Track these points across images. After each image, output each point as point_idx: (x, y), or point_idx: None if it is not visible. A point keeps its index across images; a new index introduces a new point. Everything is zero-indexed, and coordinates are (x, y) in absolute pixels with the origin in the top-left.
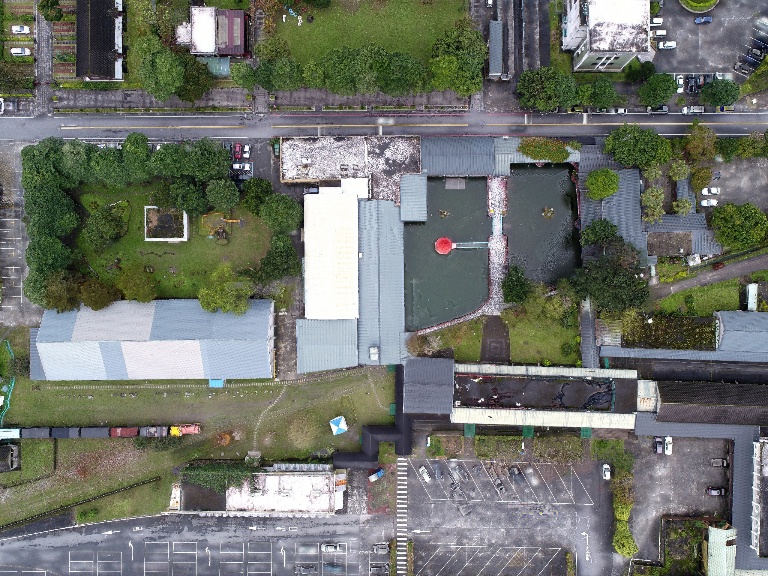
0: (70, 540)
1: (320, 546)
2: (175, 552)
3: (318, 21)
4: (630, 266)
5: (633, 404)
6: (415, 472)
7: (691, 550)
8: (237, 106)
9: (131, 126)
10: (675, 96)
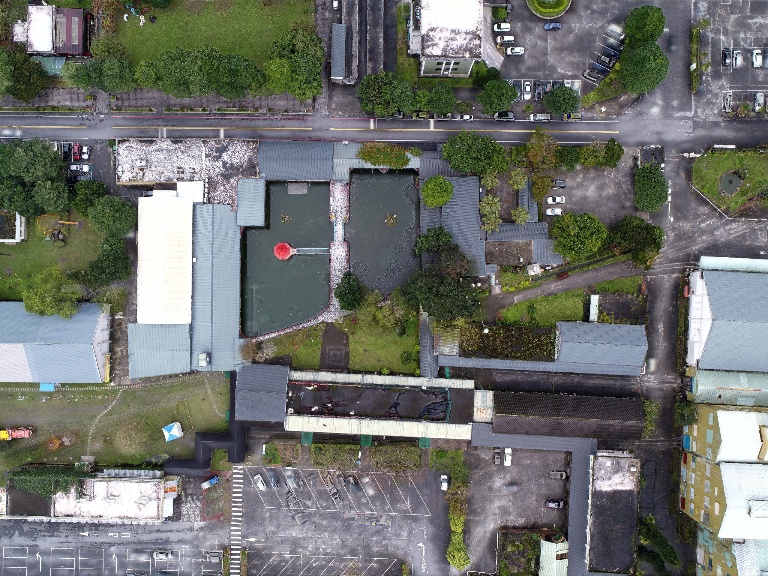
0: None
1: (153, 553)
2: (5, 557)
3: (161, 21)
4: (468, 275)
5: (469, 415)
6: (251, 480)
7: (528, 563)
8: (78, 106)
9: None
10: (523, 103)
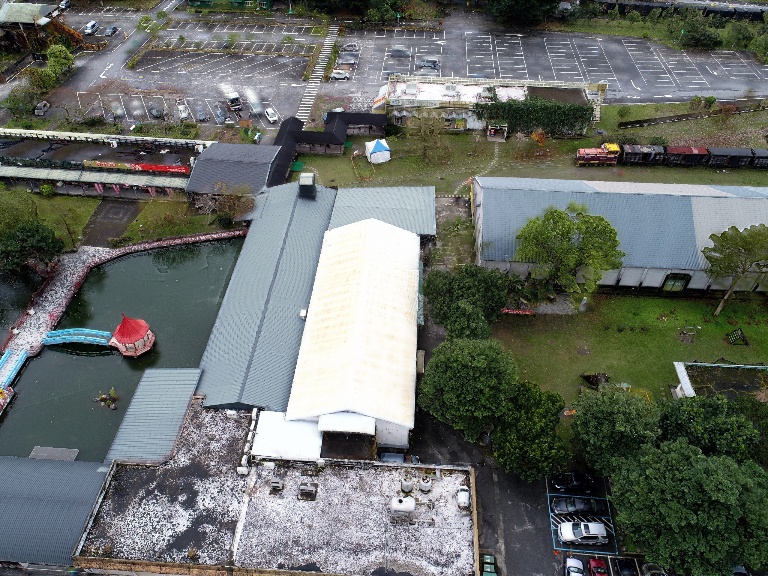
0: (714, 93)
1: None
2: None
3: None
4: None
5: None
6: None
7: None
8: None
9: None
10: None
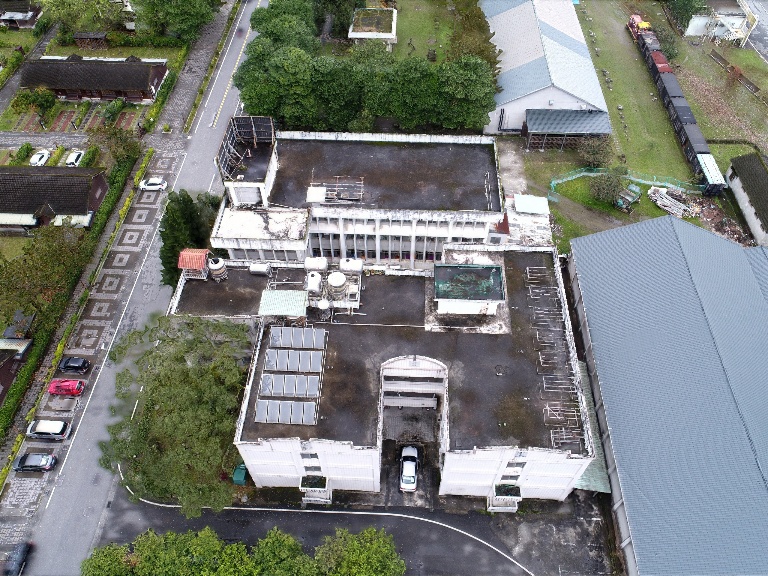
0: None
1: None
2: None
3: None
4: None
5: None
6: None
7: None
8: None
9: (233, 68)
10: None
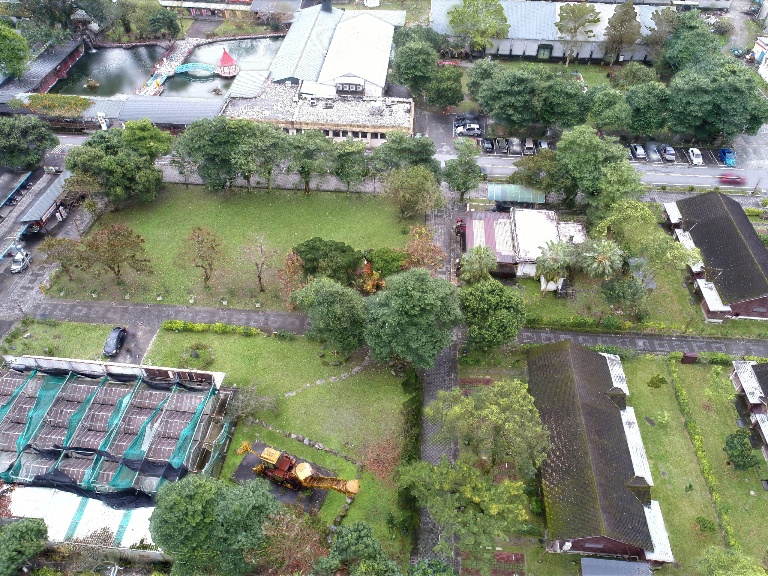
0: None
1: None
2: None
3: None
4: None
5: None
6: None
7: None
8: None
9: None
10: None
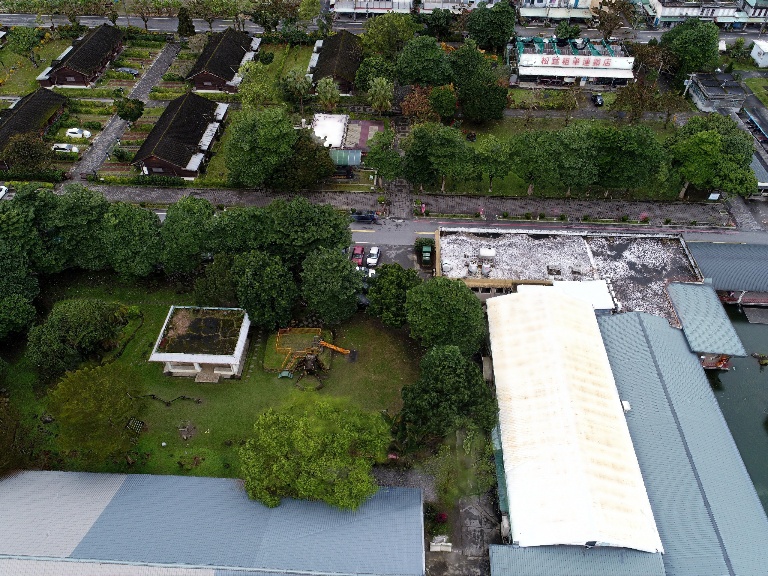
0: None
1: None
2: None
3: None
4: None
5: None
6: None
7: None
8: (361, 210)
9: None
10: None
